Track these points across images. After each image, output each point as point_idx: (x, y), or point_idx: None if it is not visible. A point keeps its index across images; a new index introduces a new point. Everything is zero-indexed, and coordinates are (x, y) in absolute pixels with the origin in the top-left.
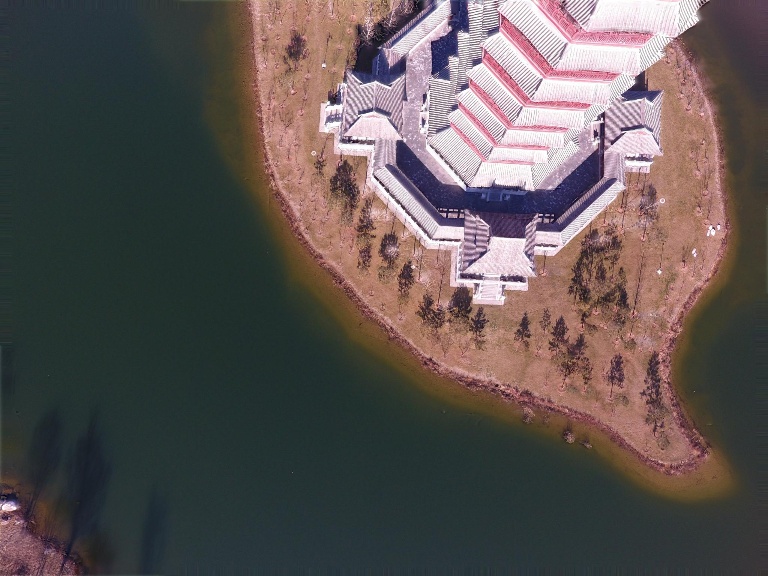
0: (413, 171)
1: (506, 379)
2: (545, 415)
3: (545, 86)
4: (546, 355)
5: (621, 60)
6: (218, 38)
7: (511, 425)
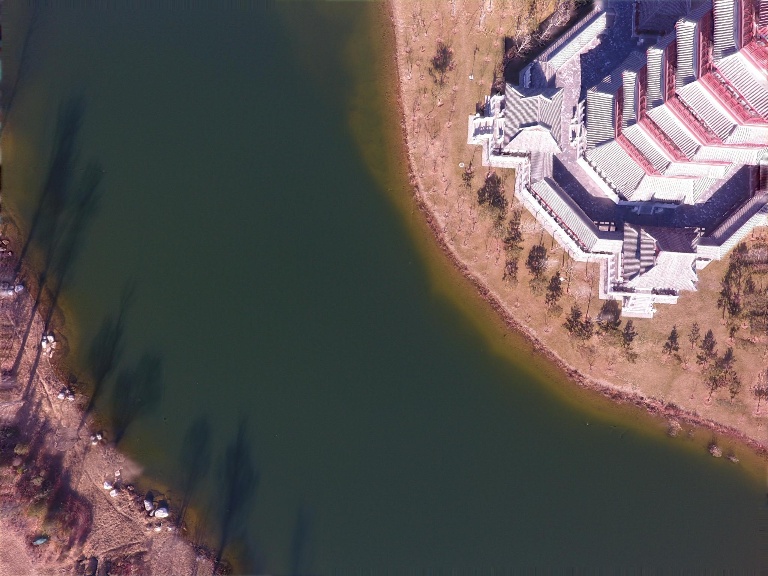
0: (564, 183)
1: (652, 392)
2: (690, 428)
3: None
4: (693, 368)
5: None
6: (360, 49)
7: (655, 438)
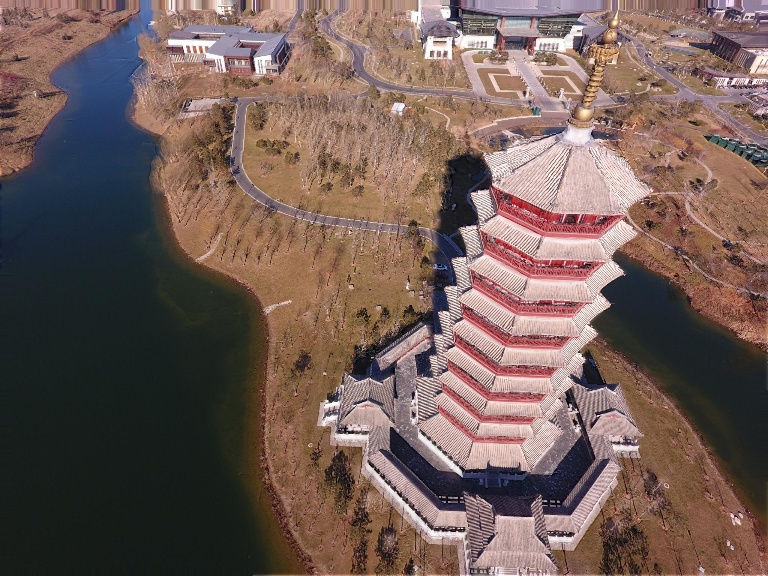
0: (407, 459)
1: None
2: None
3: (508, 353)
4: None
5: (561, 327)
6: (238, 358)
7: None
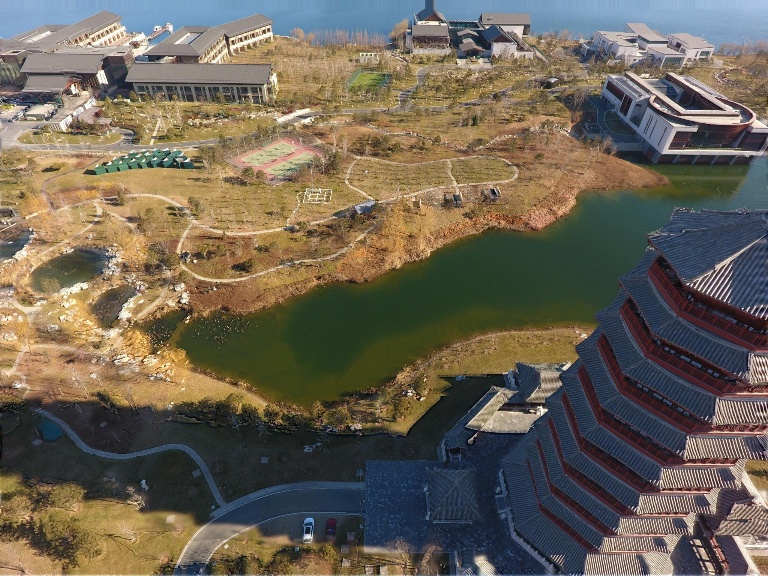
0: None
1: None
2: None
3: None
4: None
5: None
6: None
7: None
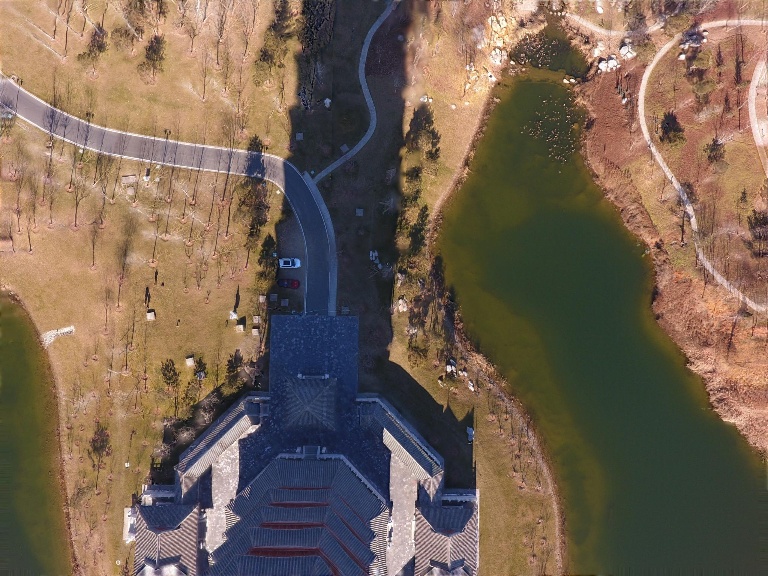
0: None
1: None
2: None
3: None
4: None
5: None
6: (24, 421)
7: None
